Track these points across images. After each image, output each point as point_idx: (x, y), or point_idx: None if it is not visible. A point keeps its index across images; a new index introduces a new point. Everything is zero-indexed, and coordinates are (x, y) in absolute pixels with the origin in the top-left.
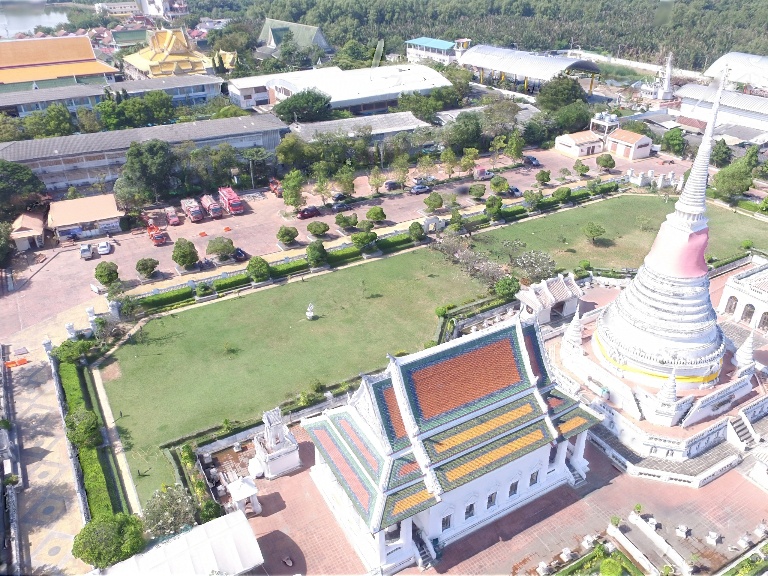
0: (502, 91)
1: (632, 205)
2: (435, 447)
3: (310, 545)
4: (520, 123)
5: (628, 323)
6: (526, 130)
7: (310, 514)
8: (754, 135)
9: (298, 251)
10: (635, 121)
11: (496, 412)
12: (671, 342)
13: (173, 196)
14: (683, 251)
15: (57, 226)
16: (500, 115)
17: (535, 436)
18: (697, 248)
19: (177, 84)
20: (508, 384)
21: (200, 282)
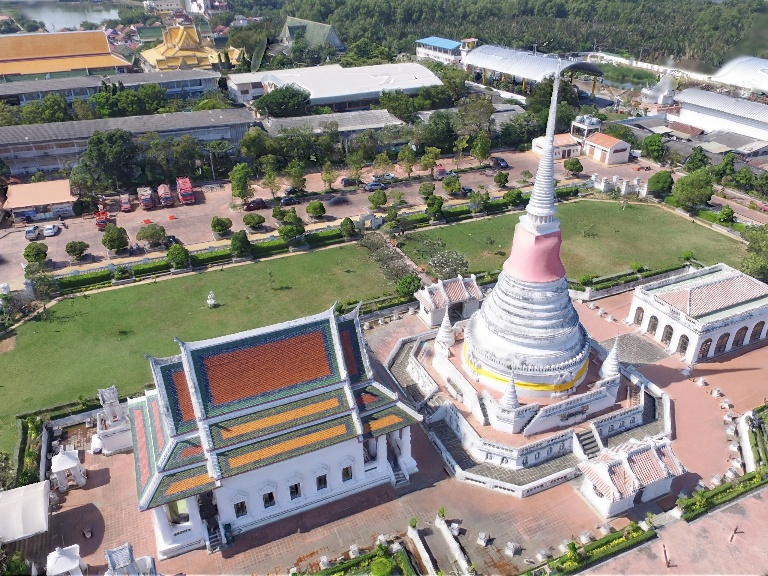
0: (500, 92)
1: (586, 210)
2: (222, 433)
3: (115, 520)
4: (500, 124)
5: (485, 326)
6: (502, 131)
7: (128, 491)
8: (744, 143)
9: (229, 241)
10: (617, 125)
11: (298, 404)
12: (521, 347)
13: (135, 184)
14: (530, 254)
15: (12, 208)
16: (474, 115)
17: (337, 430)
18: (545, 251)
19: (174, 78)
20: (315, 377)
21: (119, 266)
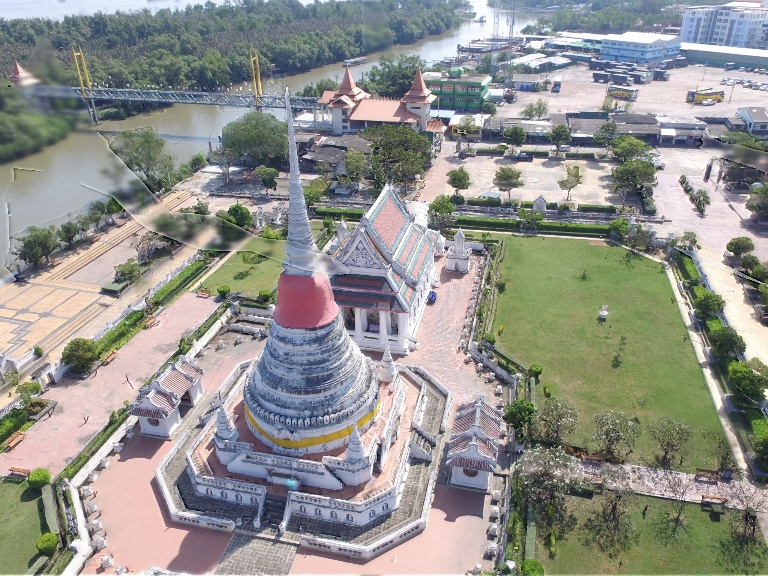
0: None
1: None
2: None
3: None
4: None
5: None
6: None
7: None
8: None
9: None
10: None
11: None
12: None
13: None
14: None
15: None
16: None
17: None
18: None
19: None
20: None
21: None
